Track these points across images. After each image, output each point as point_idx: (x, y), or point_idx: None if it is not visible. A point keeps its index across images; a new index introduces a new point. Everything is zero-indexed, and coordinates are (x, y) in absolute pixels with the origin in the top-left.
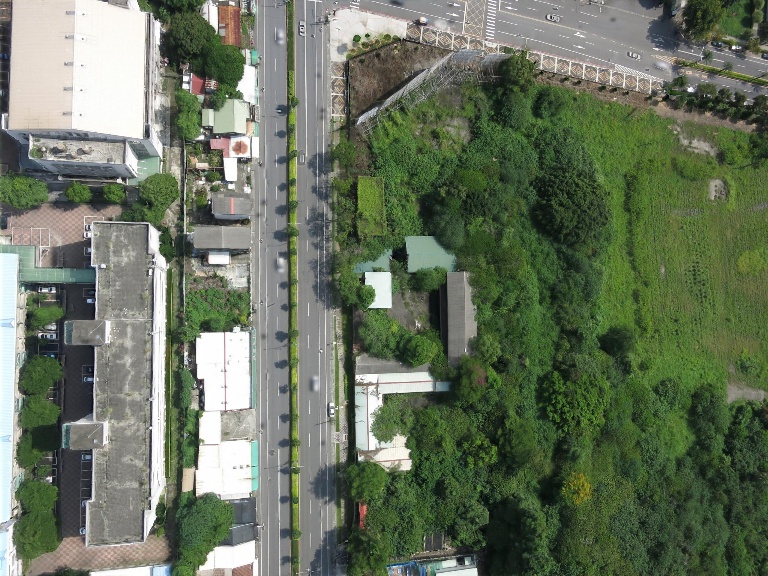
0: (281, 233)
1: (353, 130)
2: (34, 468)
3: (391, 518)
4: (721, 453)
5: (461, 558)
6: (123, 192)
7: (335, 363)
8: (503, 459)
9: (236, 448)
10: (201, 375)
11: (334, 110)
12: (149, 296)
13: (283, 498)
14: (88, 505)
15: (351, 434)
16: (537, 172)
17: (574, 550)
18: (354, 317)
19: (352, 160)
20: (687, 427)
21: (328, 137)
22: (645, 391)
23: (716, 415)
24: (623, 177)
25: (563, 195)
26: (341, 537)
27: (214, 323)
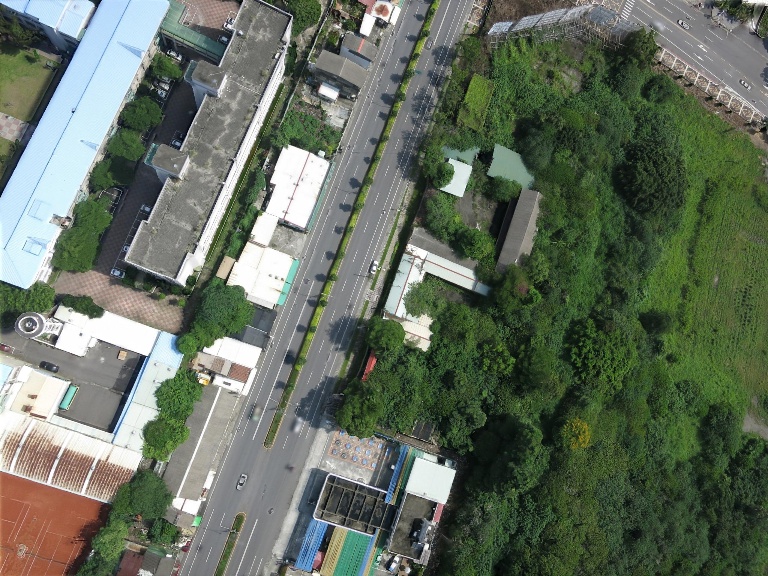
0: (388, 97)
1: (481, 40)
2: (97, 198)
3: (394, 384)
4: (723, 472)
5: (442, 459)
6: (272, 2)
7: (392, 228)
8: (516, 376)
9: (278, 259)
10: (274, 180)
11: (471, 18)
12: (268, 75)
13: (300, 327)
14: (142, 224)
15: (383, 297)
16: (631, 139)
17: (555, 493)
18: (425, 193)
19: (475, 56)
20: (696, 436)
21: (458, 37)
22: (668, 379)
23: (729, 431)
24: (704, 181)
25: (650, 162)
26: (338, 388)
27: (305, 138)
